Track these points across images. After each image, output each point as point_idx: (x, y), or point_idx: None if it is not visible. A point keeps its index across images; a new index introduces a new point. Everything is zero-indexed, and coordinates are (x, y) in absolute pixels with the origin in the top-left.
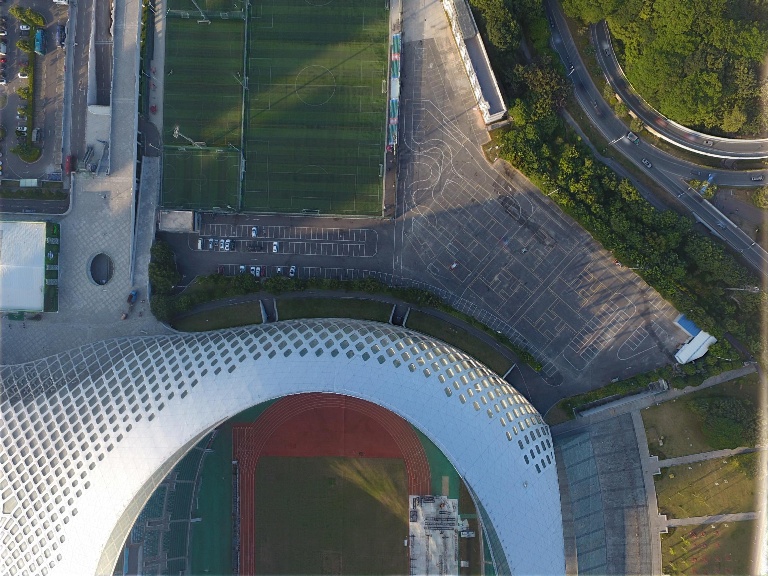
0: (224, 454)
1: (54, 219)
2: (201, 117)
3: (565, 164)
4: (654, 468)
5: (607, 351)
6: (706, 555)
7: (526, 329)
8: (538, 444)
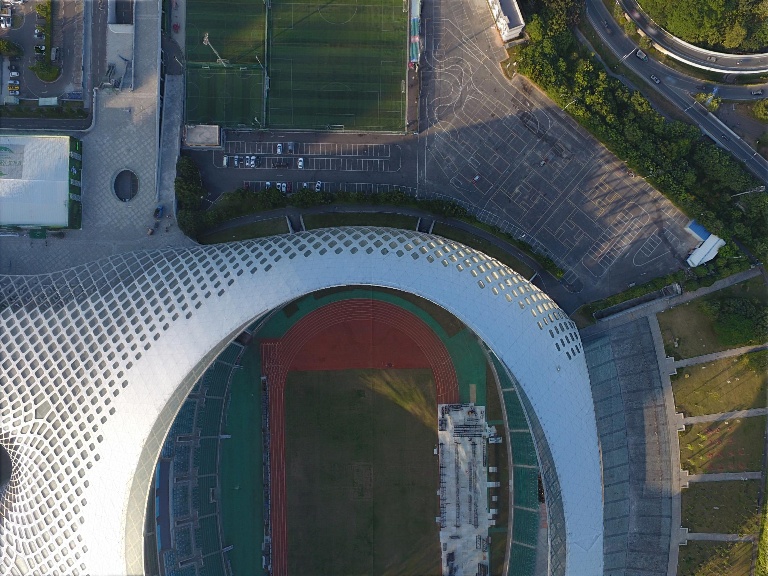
0: (253, 370)
1: (76, 135)
2: (224, 36)
3: (581, 77)
4: (670, 369)
5: (623, 258)
6: (721, 450)
7: (546, 239)
8: (567, 335)
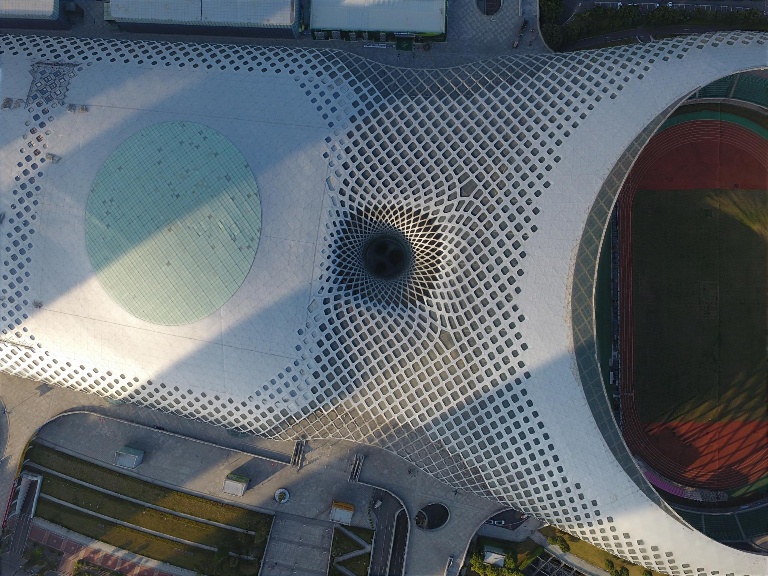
0: None
1: None
2: None
3: None
4: None
5: None
6: None
7: None
8: None
